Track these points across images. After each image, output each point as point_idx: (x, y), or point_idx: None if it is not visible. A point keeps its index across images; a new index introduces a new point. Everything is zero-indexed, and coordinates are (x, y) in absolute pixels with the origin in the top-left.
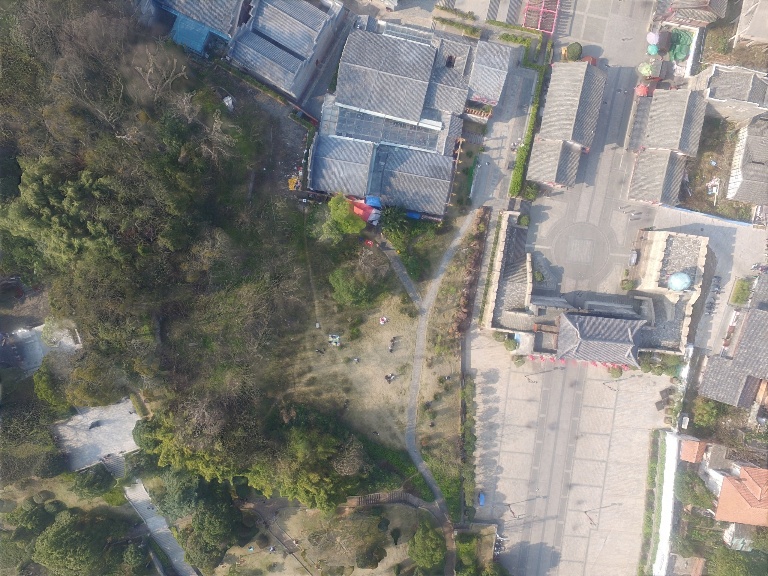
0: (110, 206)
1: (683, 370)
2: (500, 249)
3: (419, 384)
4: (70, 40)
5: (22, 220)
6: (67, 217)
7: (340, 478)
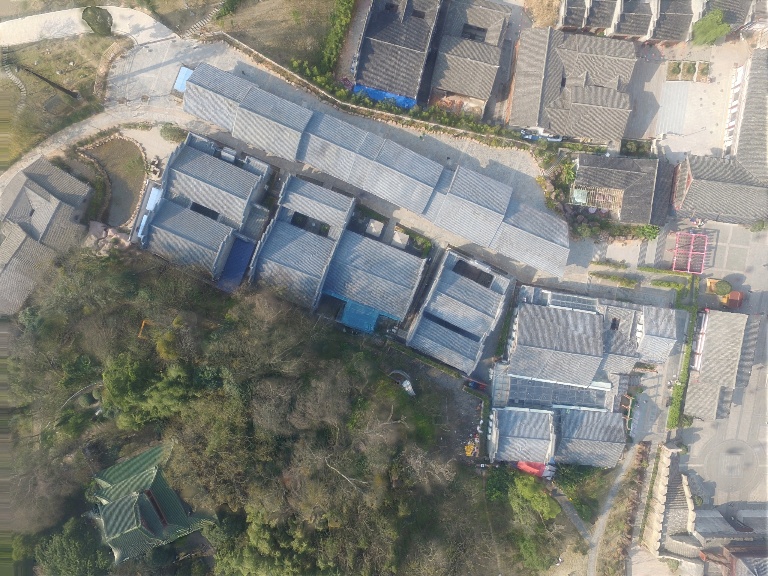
0: (334, 539)
1: None
2: (663, 483)
3: None
4: (303, 416)
5: (259, 571)
6: (297, 557)
7: None
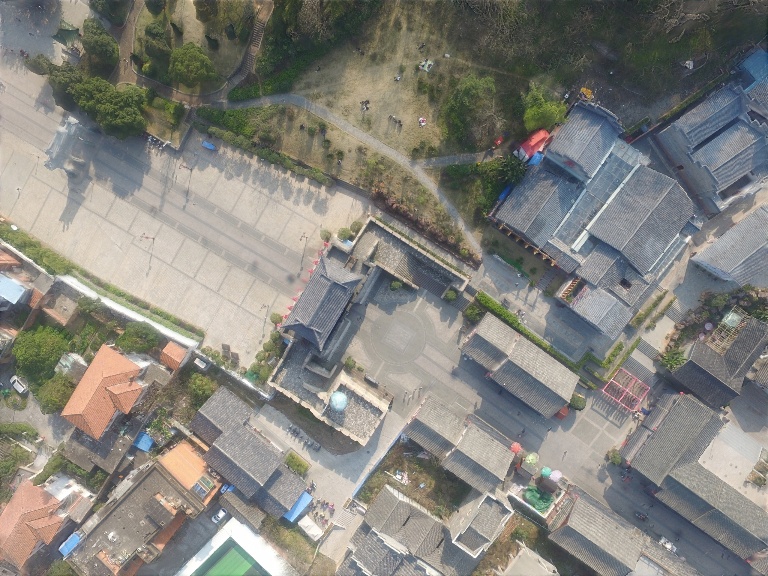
0: None
1: (249, 382)
2: None
3: (346, 132)
4: None
5: None
6: None
7: (299, 2)
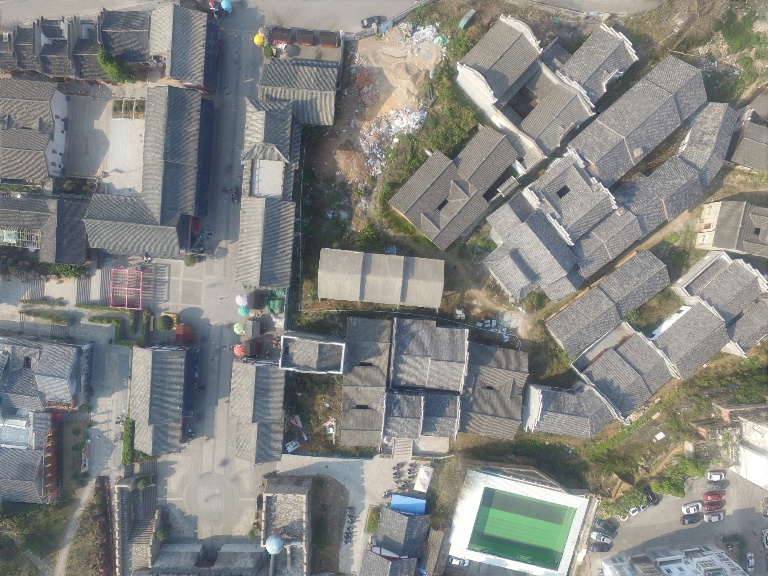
0: None
1: None
2: (116, 519)
3: None
4: None
5: None
6: None
7: None
